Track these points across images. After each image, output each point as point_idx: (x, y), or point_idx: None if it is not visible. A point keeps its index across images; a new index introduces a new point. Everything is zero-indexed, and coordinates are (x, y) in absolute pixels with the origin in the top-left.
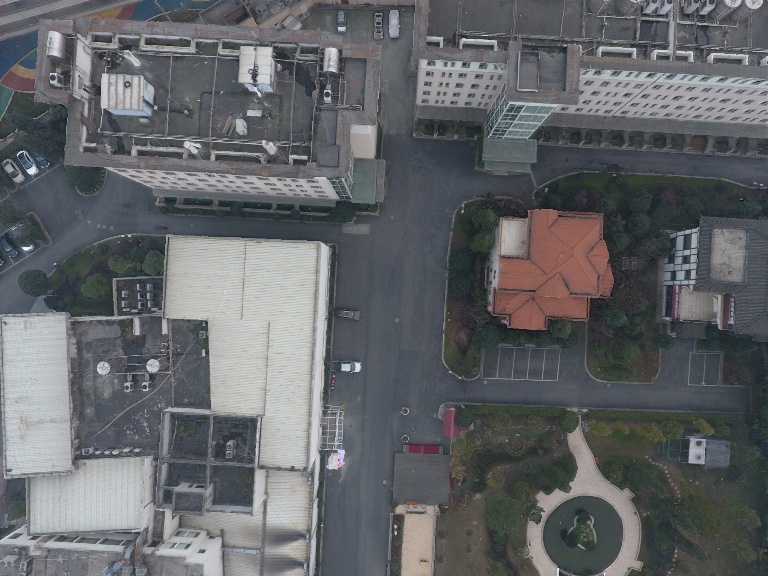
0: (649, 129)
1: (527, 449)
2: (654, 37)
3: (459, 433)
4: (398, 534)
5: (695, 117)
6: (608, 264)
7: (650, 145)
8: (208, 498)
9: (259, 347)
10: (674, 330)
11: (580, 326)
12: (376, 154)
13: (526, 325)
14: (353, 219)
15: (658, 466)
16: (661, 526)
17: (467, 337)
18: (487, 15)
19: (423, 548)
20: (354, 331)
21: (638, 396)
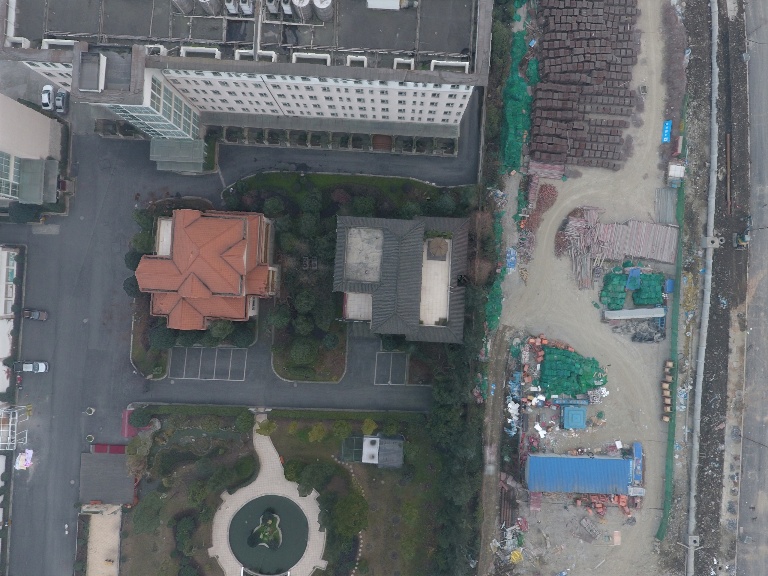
0: (323, 128)
1: (212, 449)
2: (243, 37)
3: (137, 433)
4: (82, 534)
5: (363, 116)
6: (267, 264)
7: (337, 144)
8: None
9: None
10: None
11: None
12: (60, 154)
13: (177, 325)
14: (40, 219)
15: (344, 465)
16: None
17: None
18: (77, 15)
19: (109, 547)
20: (43, 331)
21: (324, 395)
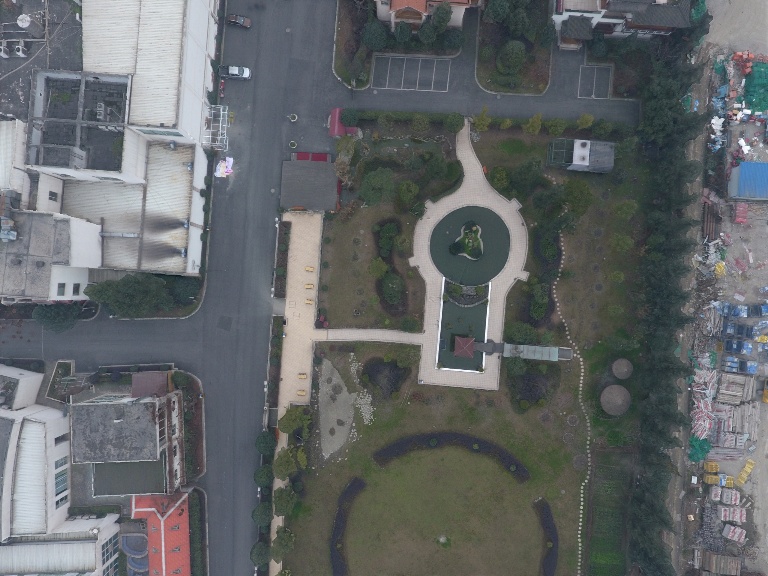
0: None
1: (415, 157)
2: None
3: (345, 134)
4: (284, 239)
5: None
6: None
7: None
8: (77, 156)
9: (131, 6)
10: (563, 38)
11: (471, 37)
12: None
13: (404, 3)
14: None
15: (546, 177)
16: (543, 222)
17: (356, 44)
18: None
19: (309, 256)
20: (245, 40)
21: (528, 108)
